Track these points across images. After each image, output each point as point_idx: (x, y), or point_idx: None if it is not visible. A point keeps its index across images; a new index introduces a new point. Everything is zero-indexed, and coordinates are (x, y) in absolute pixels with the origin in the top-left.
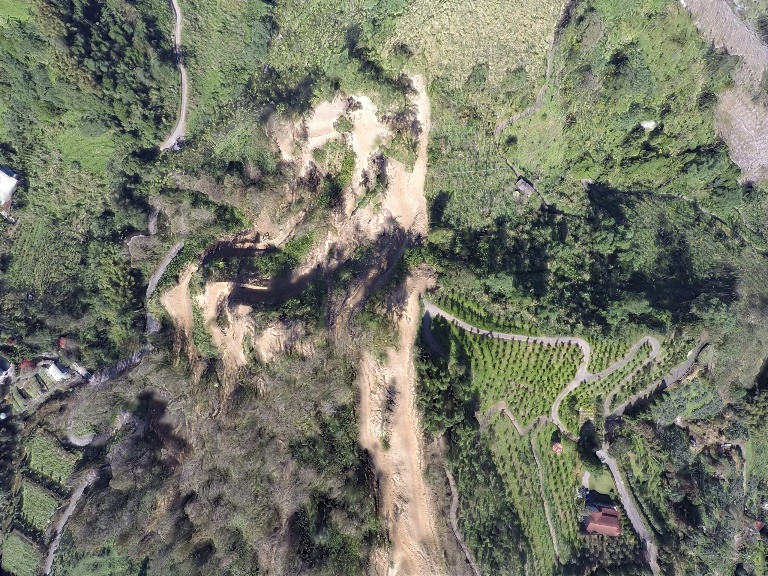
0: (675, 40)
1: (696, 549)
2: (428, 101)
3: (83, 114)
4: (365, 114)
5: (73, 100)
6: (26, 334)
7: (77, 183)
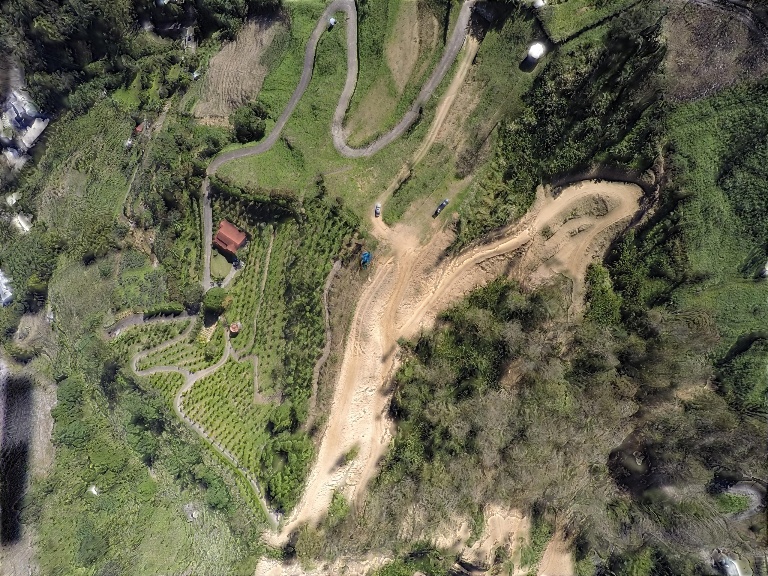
0: None
1: (173, 173)
2: None
3: None
4: None
5: None
6: None
7: None
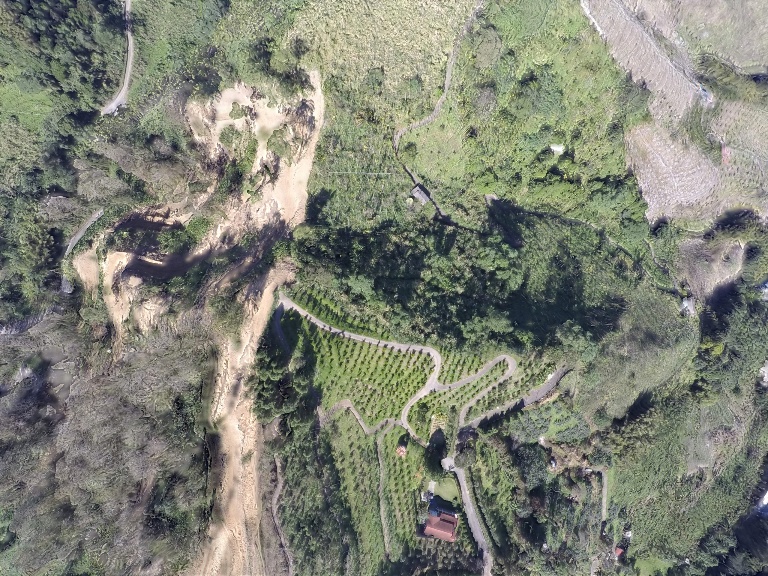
0: (588, 67)
1: (530, 564)
2: (322, 98)
3: (22, 70)
4: None
5: (11, 55)
6: None
7: (14, 138)
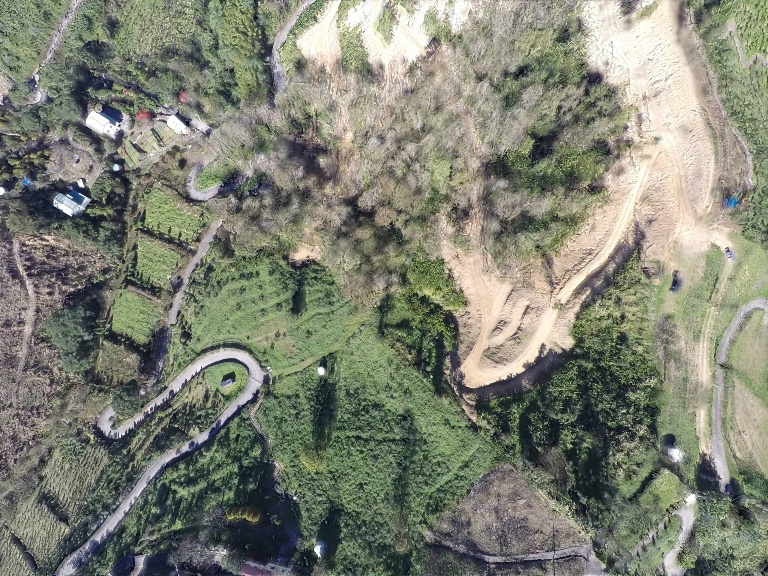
0: None
1: None
2: None
3: None
4: None
5: None
6: (145, 79)
7: None
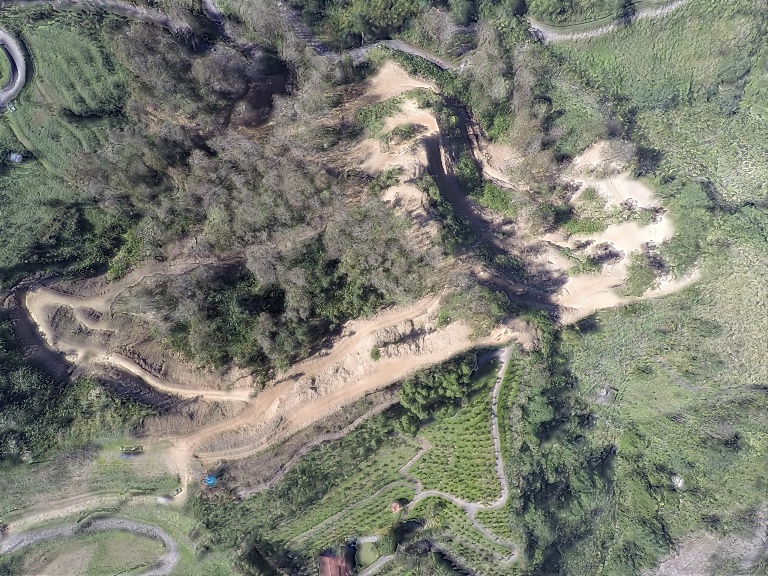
0: (767, 488)
1: None
2: (685, 288)
3: None
4: (650, 228)
5: None
6: None
7: None
